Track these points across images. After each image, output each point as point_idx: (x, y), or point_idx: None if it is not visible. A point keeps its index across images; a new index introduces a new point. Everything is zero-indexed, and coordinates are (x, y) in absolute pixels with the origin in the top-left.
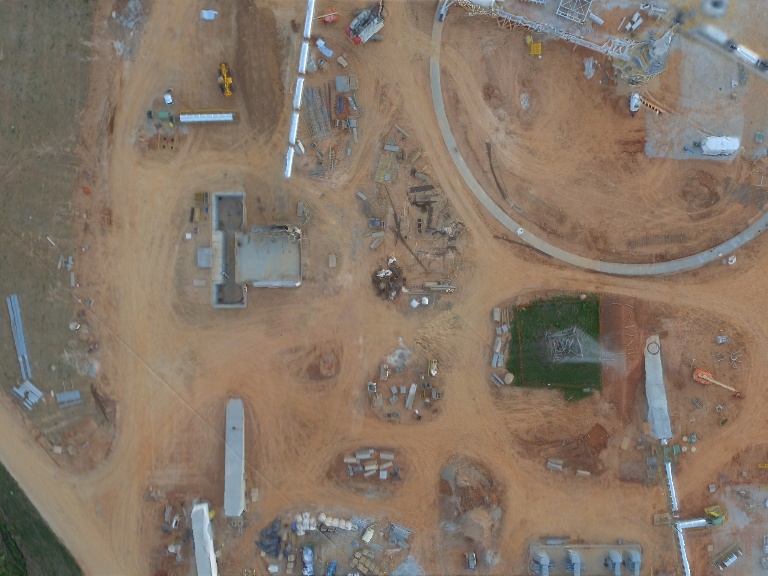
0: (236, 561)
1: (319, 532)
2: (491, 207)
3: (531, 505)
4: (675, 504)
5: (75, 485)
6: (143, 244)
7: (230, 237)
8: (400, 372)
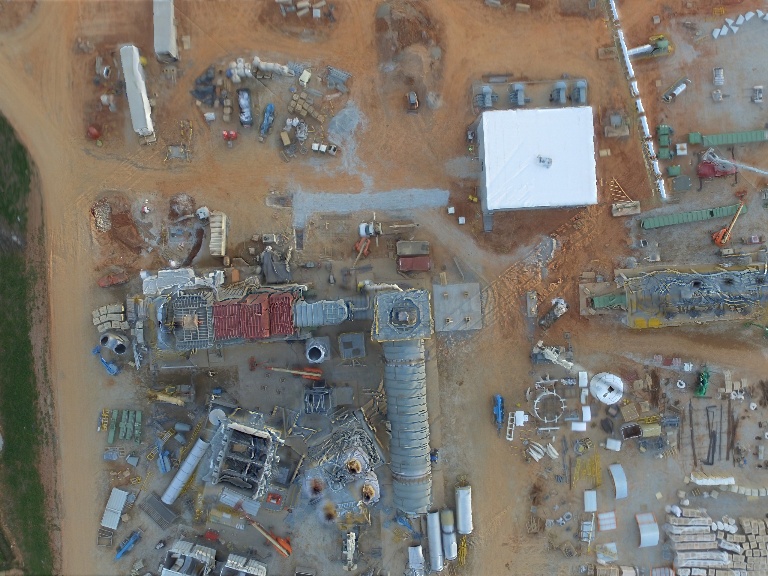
0: (172, 112)
1: (255, 79)
2: None
3: (471, 44)
4: (616, 16)
5: (2, 44)
6: None
7: None
8: None
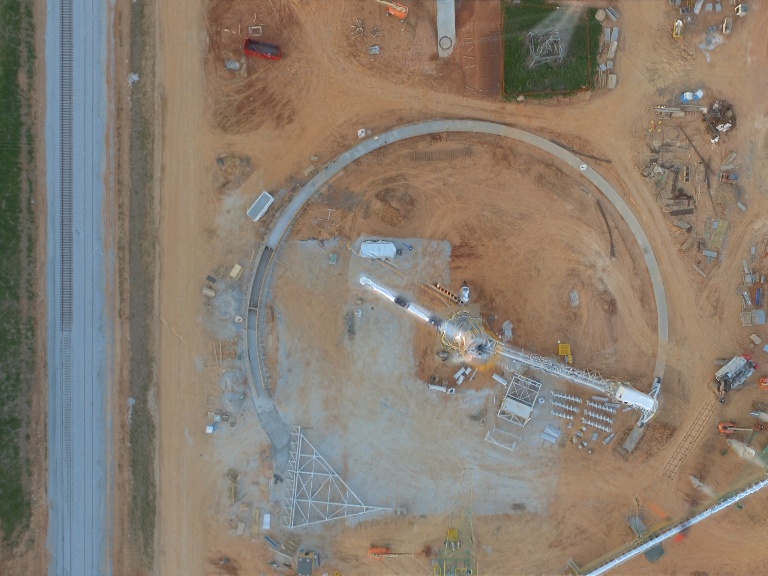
0: None
1: None
2: (612, 193)
3: None
4: None
5: None
6: None
7: None
8: (711, 26)
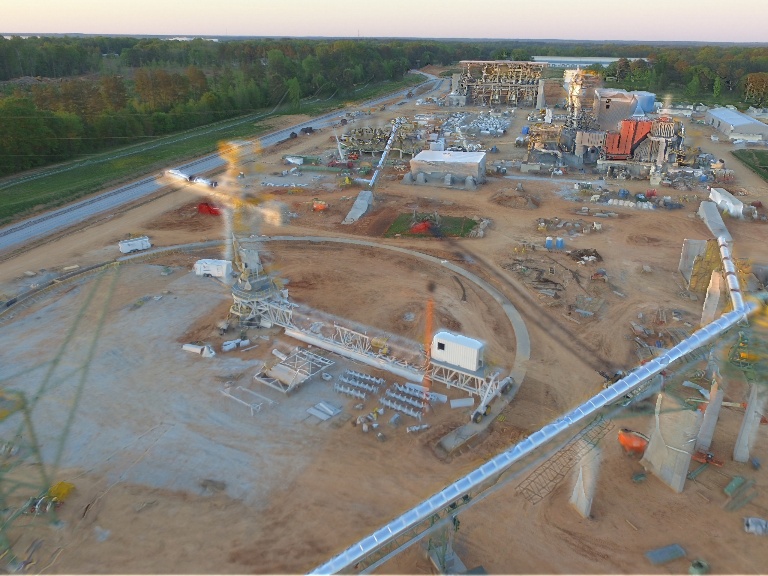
0: None
1: None
2: (471, 275)
3: (471, 197)
4: None
5: None
6: None
7: None
8: None
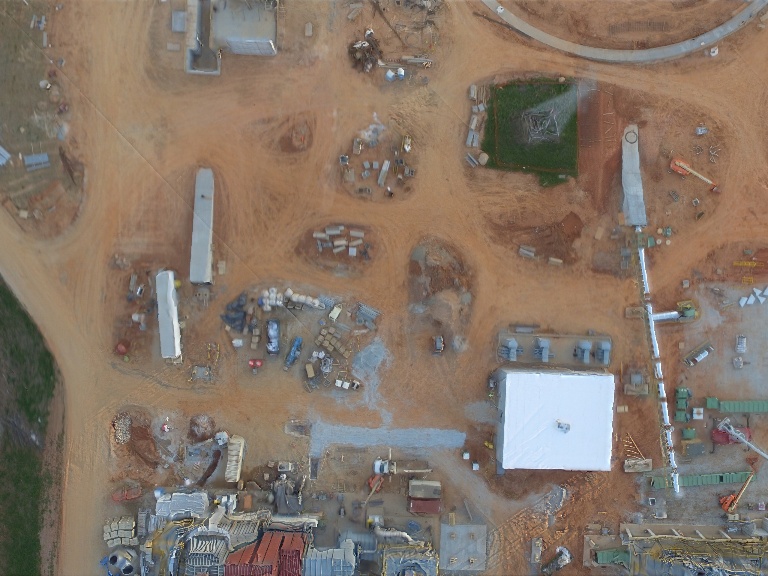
0: (200, 334)
1: (286, 309)
2: None
3: (502, 292)
4: (647, 288)
5: (40, 251)
6: (117, 5)
7: (206, 7)
8: (373, 147)
